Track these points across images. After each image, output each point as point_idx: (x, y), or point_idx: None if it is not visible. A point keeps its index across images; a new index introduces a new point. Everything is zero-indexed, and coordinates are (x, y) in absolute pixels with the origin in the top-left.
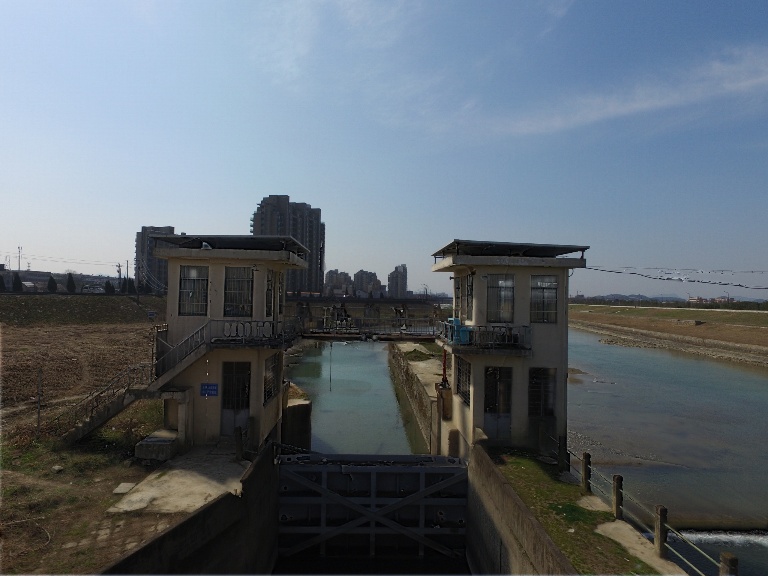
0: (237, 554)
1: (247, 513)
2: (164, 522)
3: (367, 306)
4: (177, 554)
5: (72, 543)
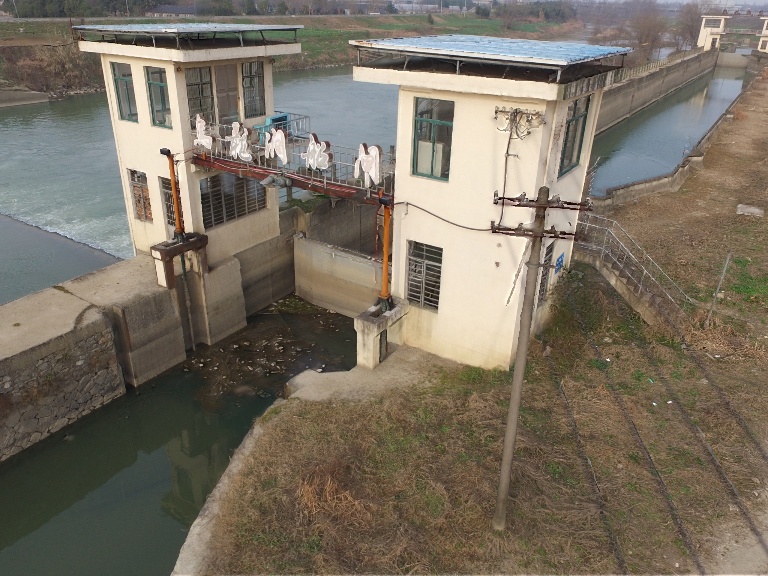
0: None
1: None
2: None
3: None
4: None
5: None
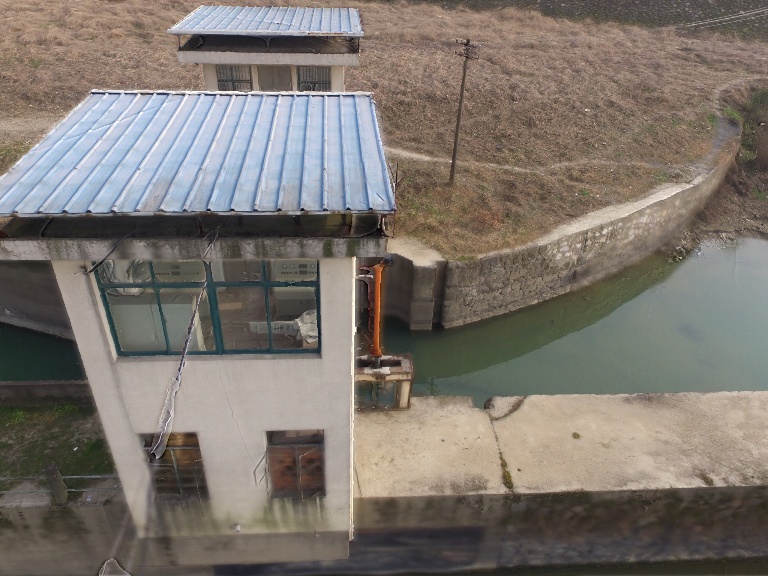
0: None
1: None
2: None
3: None
4: None
5: None
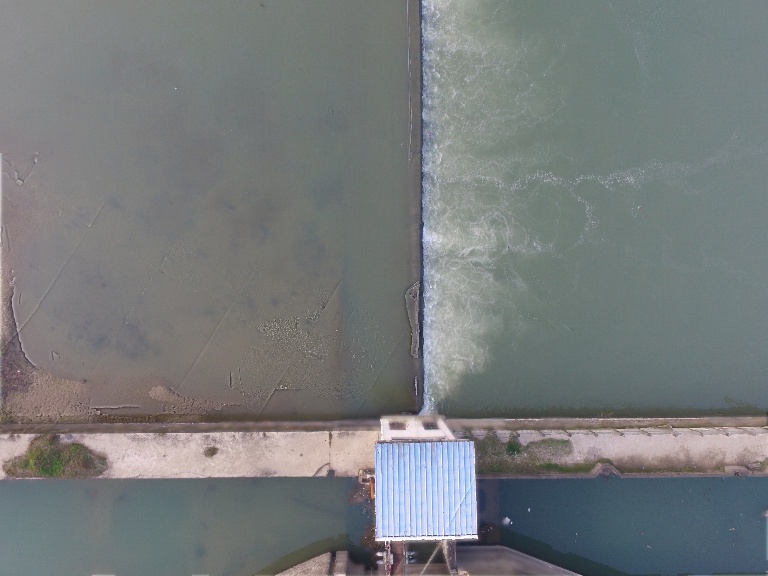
0: None
1: None
2: None
3: (388, 572)
4: None
5: None
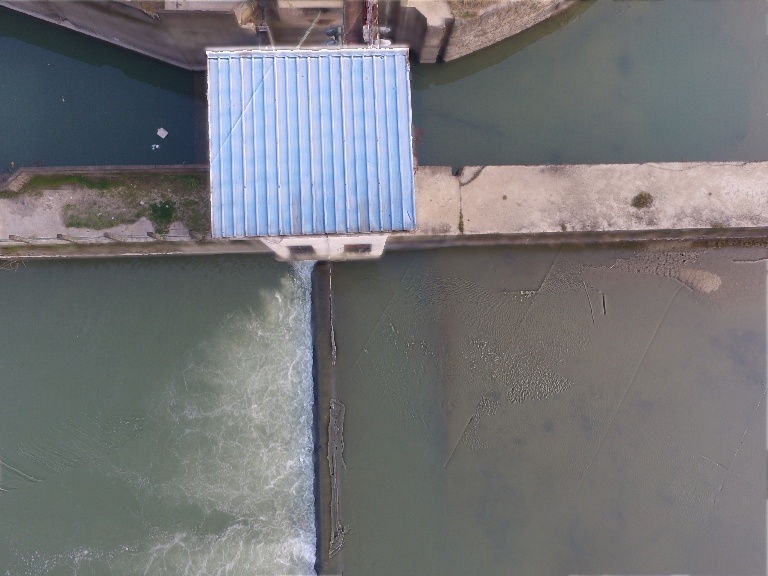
0: (161, 36)
1: (165, 27)
2: None
3: None
4: (109, 6)
5: None
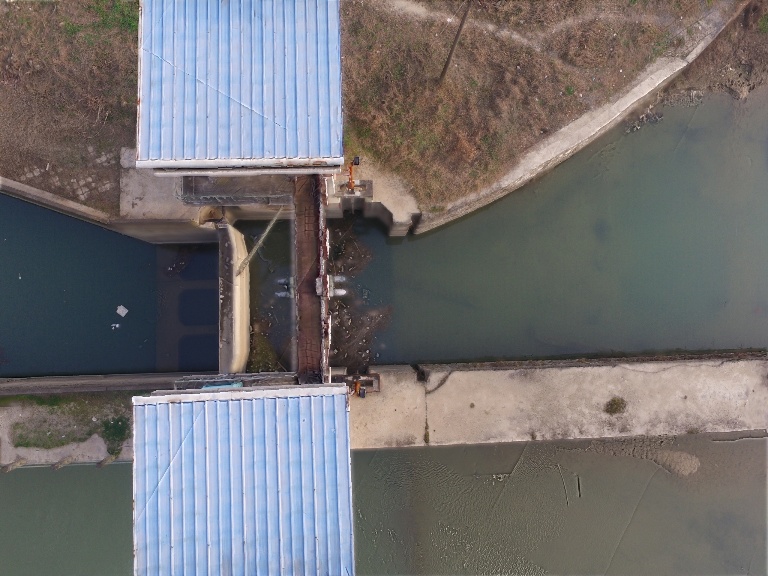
0: None
1: (120, 228)
2: (112, 185)
3: None
4: None
5: (92, 149)
